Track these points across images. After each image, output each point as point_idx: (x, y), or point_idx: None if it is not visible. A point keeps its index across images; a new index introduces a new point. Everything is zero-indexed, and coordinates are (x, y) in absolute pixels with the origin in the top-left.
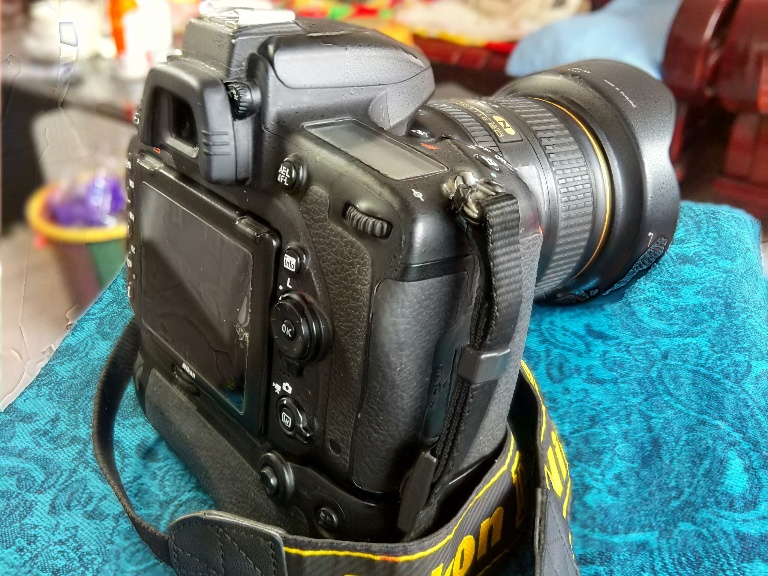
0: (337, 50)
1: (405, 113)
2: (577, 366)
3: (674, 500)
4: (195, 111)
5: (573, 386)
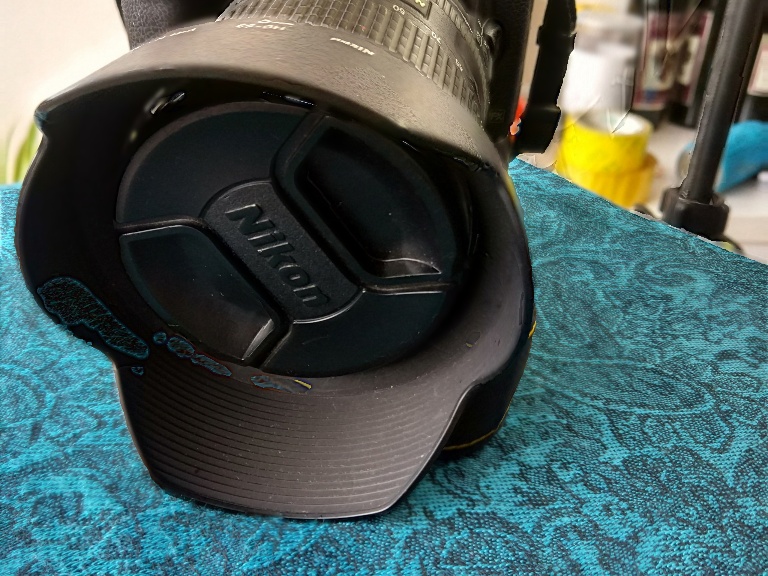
0: None
1: None
2: None
3: (6, 288)
4: None
5: None
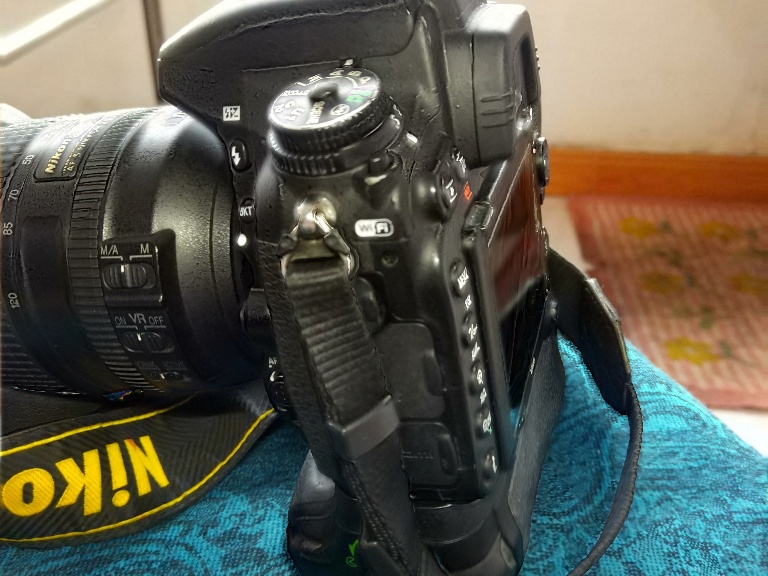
0: None
1: None
2: None
3: None
4: (530, 34)
5: None
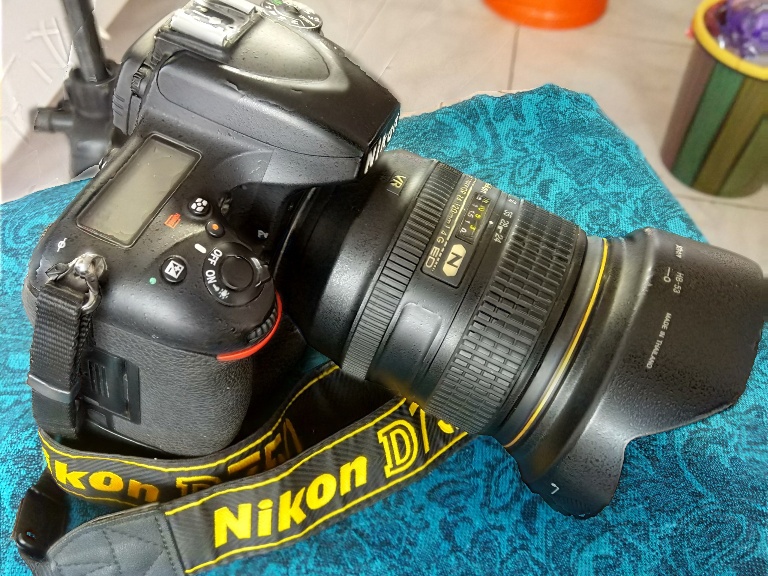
0: (230, 93)
1: (292, 180)
2: (464, 508)
3: None
4: None
5: (428, 513)
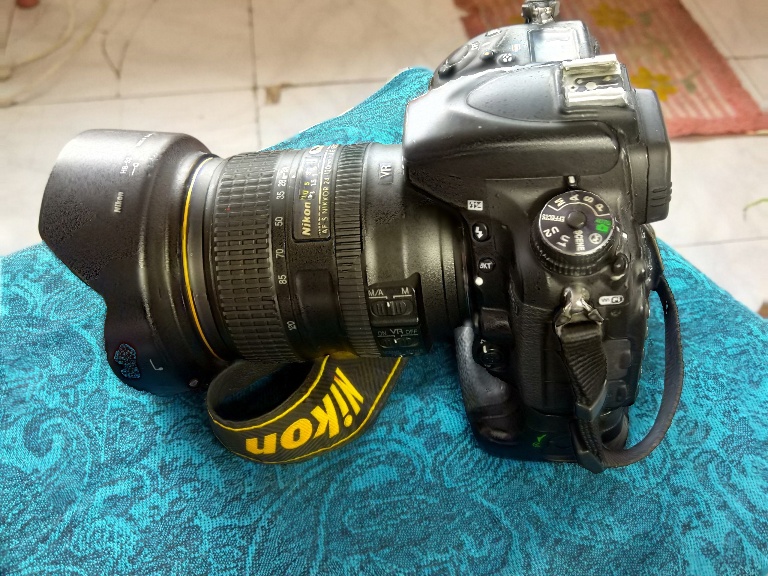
0: None
1: None
2: None
3: None
4: None
5: None
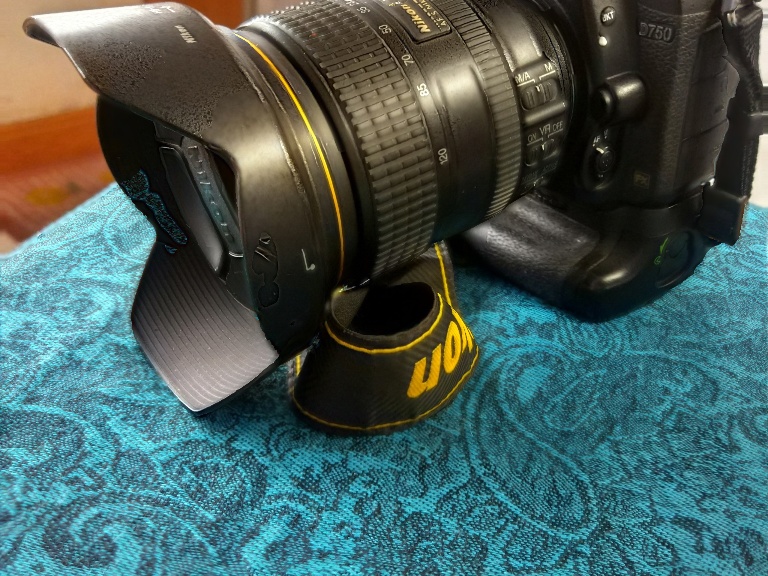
0: None
1: None
2: None
3: None
4: None
5: None
